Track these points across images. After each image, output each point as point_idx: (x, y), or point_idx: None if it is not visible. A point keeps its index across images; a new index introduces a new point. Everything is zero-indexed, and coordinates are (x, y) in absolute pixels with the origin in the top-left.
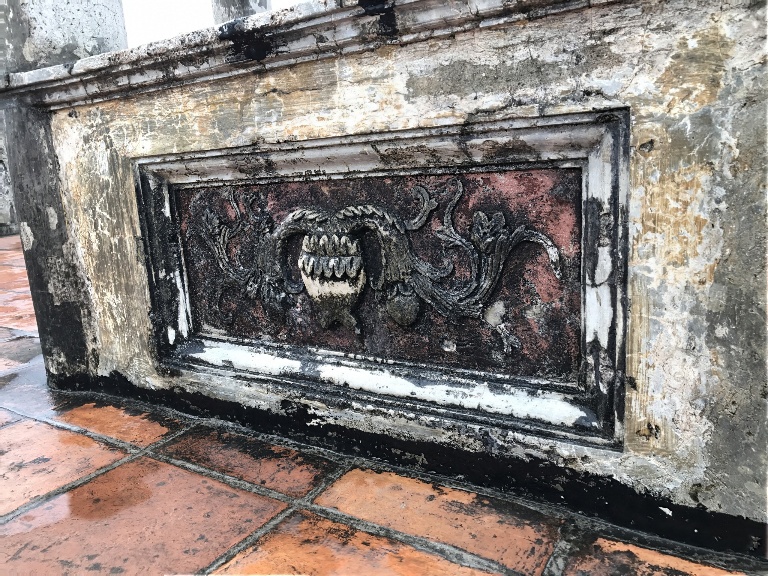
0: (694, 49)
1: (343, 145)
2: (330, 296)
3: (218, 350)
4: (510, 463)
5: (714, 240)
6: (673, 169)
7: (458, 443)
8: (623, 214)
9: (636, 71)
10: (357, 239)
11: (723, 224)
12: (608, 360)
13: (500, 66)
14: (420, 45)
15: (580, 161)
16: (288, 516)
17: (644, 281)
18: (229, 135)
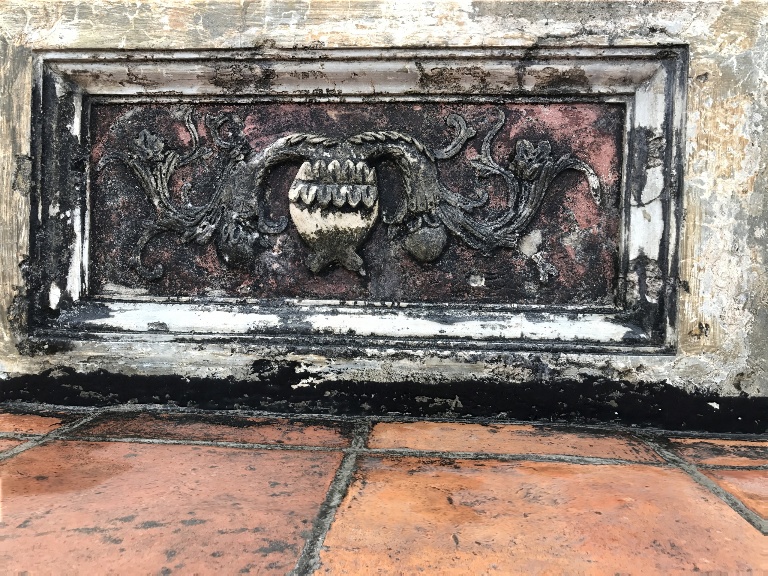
0: (739, 5)
1: (379, 60)
2: (334, 230)
3: (136, 313)
4: (562, 387)
5: (754, 156)
6: (723, 98)
7: (502, 376)
8: (677, 136)
9: (694, 17)
10: (374, 167)
11: (761, 143)
12: (657, 271)
13: None
14: None
15: (625, 97)
16: (358, 458)
17: (698, 192)
18: (220, 34)
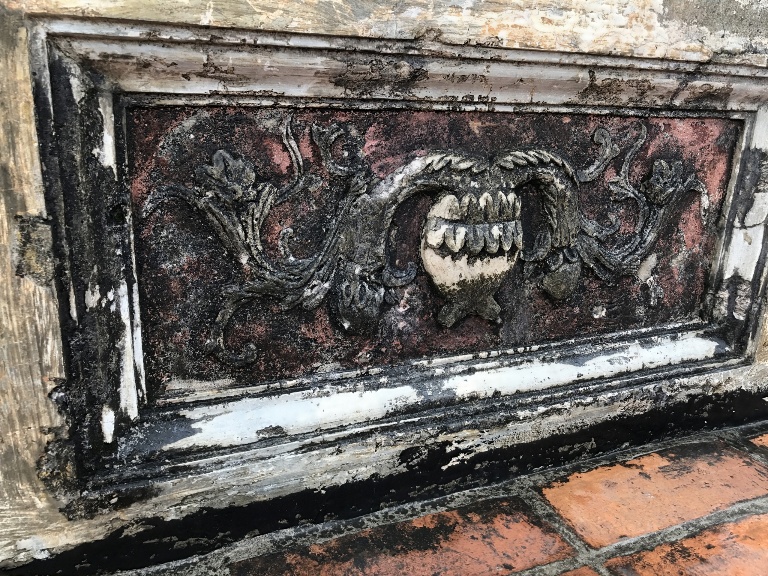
0: None
1: (553, 65)
2: (479, 279)
3: (231, 417)
4: (673, 410)
5: None
6: None
7: (630, 411)
8: None
9: None
10: None
11: None
12: (748, 291)
13: (748, 7)
14: None
15: (746, 114)
16: None
17: None
18: (367, 13)
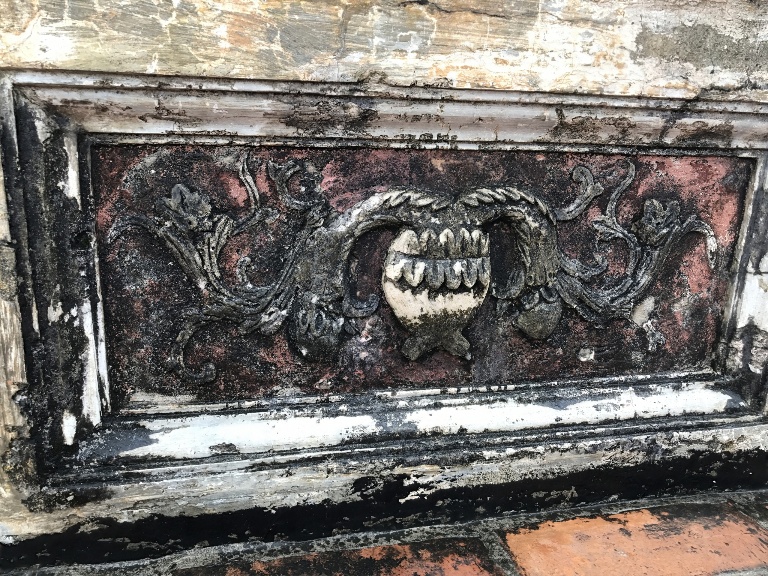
0: None
1: (514, 104)
2: (443, 314)
3: (188, 432)
4: (672, 465)
5: None
6: None
7: (618, 461)
8: None
9: None
10: (488, 233)
11: None
12: (766, 342)
13: (743, 41)
14: None
15: (758, 152)
16: None
17: None
18: (307, 59)
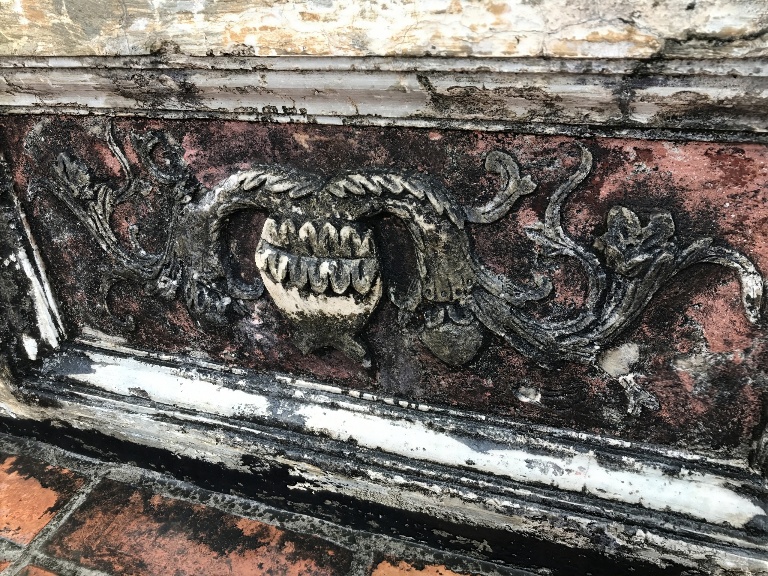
0: None
1: (354, 70)
2: (319, 316)
3: (117, 370)
4: (633, 566)
5: None
6: None
7: (547, 535)
8: None
9: None
10: (369, 230)
11: None
12: None
13: None
14: None
15: None
16: None
17: None
18: (96, 31)
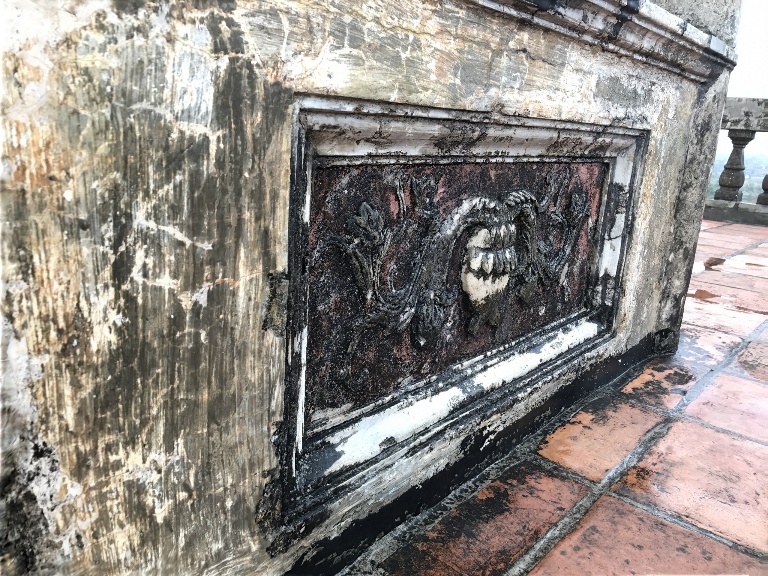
0: (665, 104)
1: None
2: None
3: (359, 436)
4: None
5: None
6: None
7: None
8: None
9: None
10: None
11: None
12: None
13: None
14: (609, 55)
15: None
16: None
17: None
18: (472, 92)
